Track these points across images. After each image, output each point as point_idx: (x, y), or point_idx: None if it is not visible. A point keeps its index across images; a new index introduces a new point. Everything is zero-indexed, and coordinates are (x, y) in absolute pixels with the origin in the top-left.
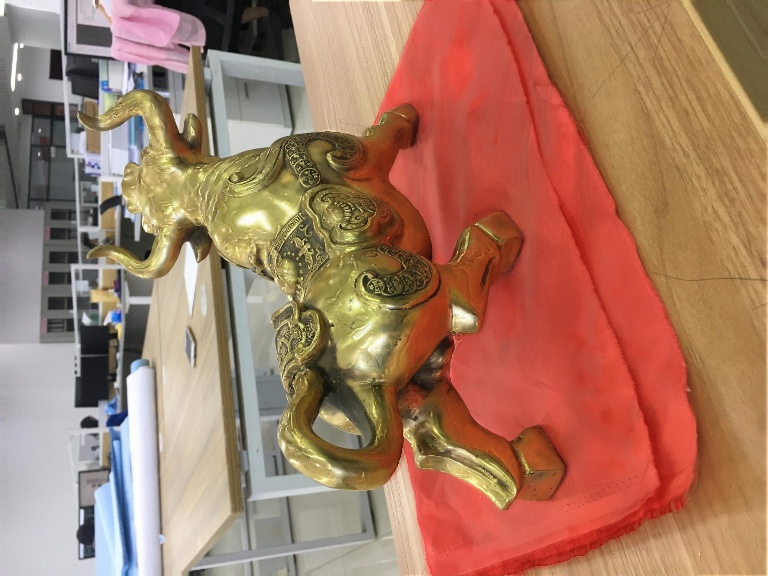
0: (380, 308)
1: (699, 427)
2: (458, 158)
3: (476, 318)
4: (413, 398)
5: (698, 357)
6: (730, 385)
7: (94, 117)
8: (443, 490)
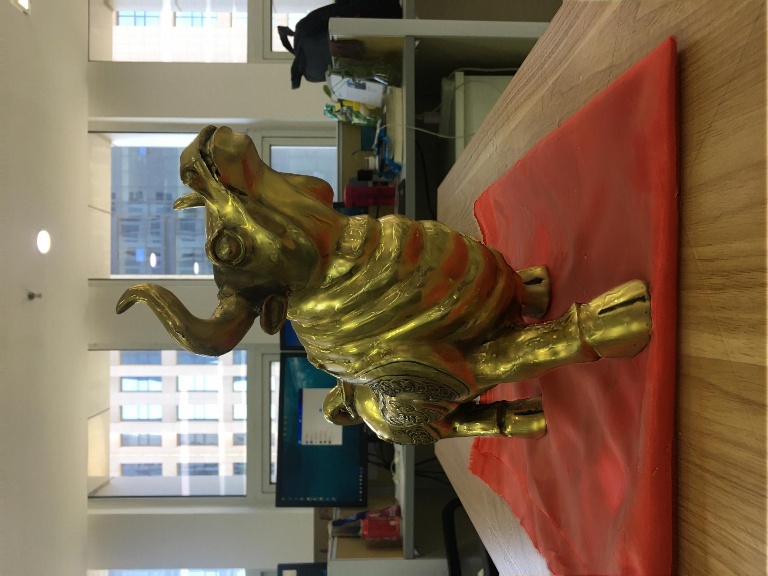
0: None
1: None
2: (580, 405)
3: None
4: None
5: None
6: None
7: None
8: None
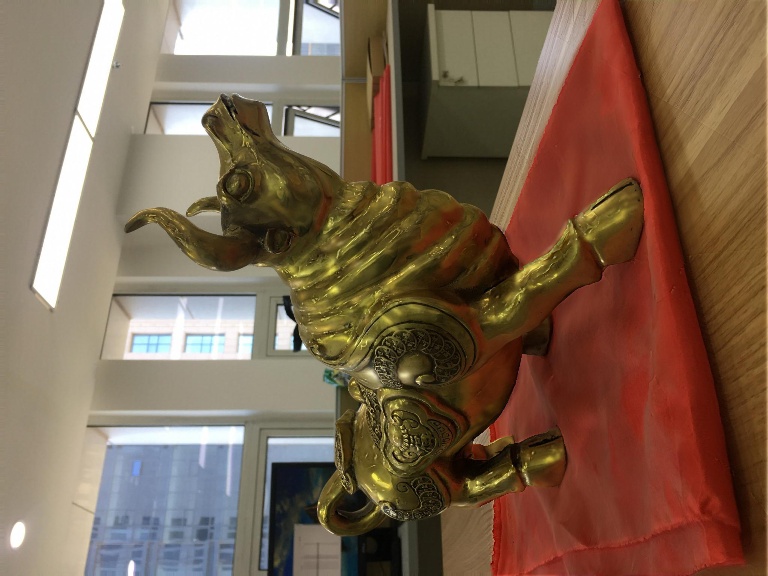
0: None
1: None
2: (595, 378)
3: None
4: None
5: None
6: None
7: (147, 221)
8: None
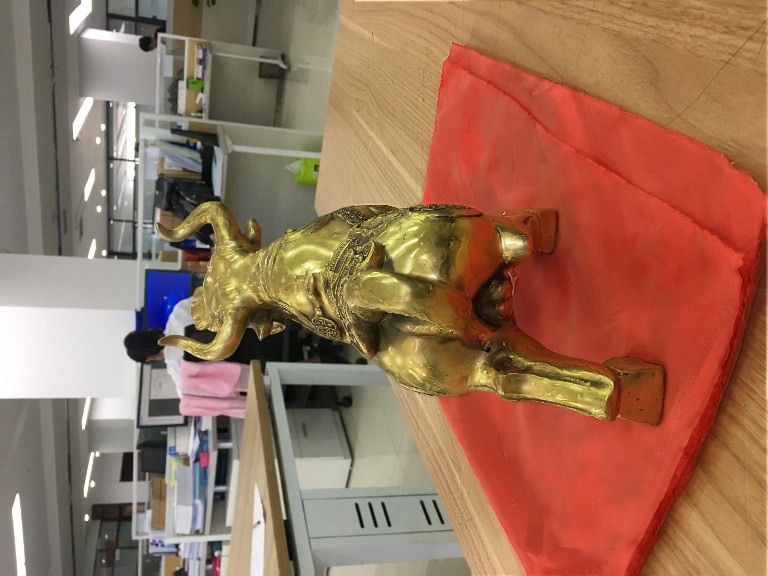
0: (428, 218)
1: (756, 179)
2: (487, 212)
3: (524, 237)
4: (481, 329)
5: (731, 143)
6: (767, 134)
7: None
8: (552, 535)
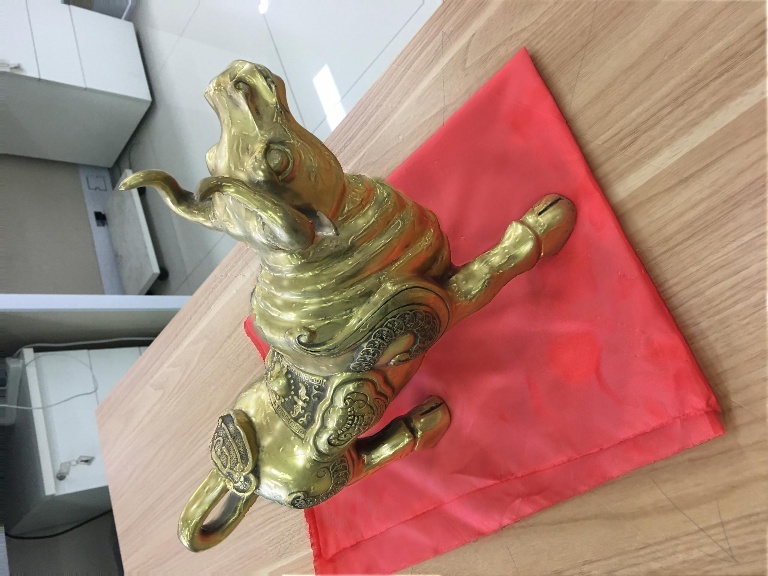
0: None
1: None
2: (499, 348)
3: None
4: None
5: None
6: None
7: (218, 190)
8: None
